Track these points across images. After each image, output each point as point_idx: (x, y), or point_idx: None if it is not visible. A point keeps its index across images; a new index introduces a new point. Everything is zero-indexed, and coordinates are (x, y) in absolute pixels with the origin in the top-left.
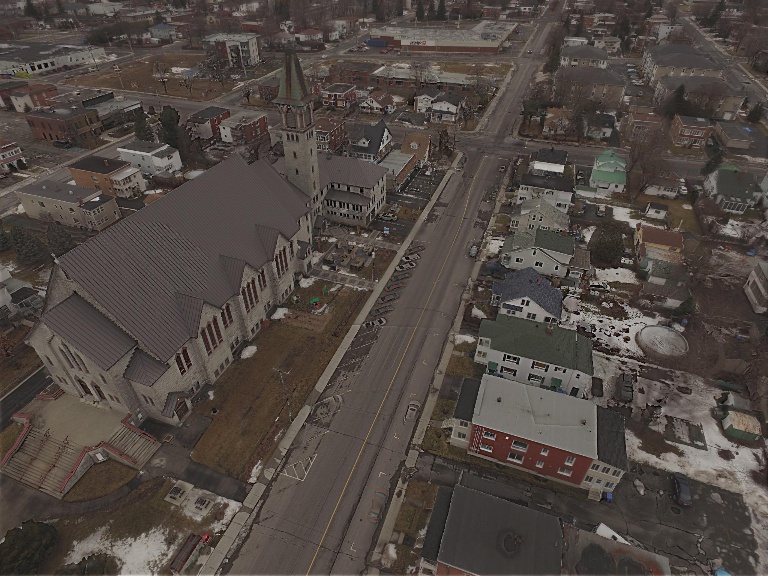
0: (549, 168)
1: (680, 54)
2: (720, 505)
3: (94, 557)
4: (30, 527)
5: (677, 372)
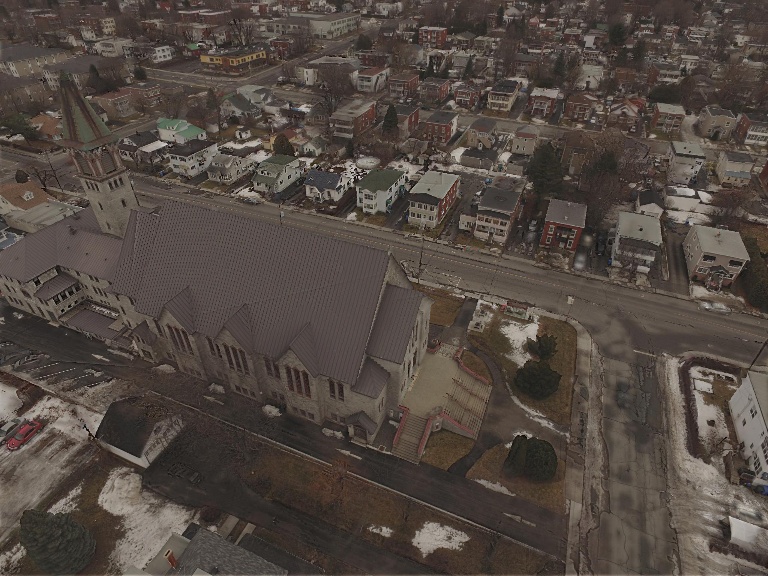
0: (156, 147)
1: (14, 48)
2: None
3: (529, 345)
4: (528, 365)
5: (389, 165)
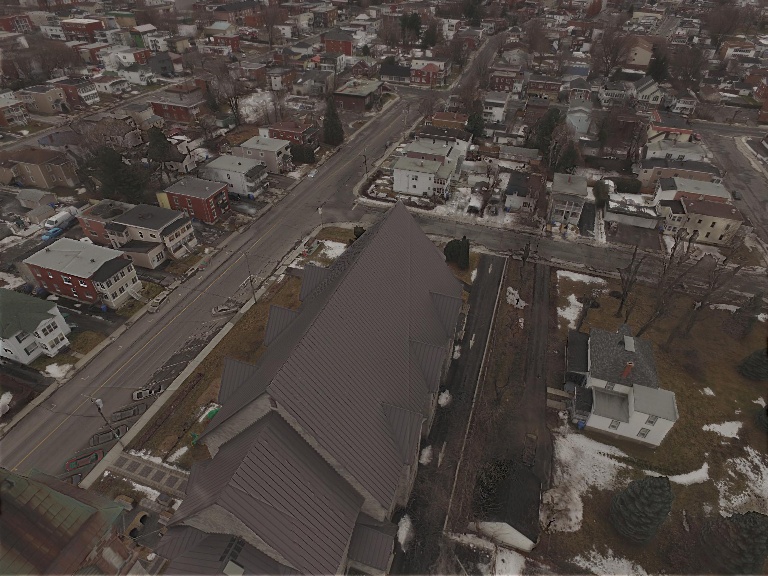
0: None
1: None
2: (2, 260)
3: None
4: None
5: None
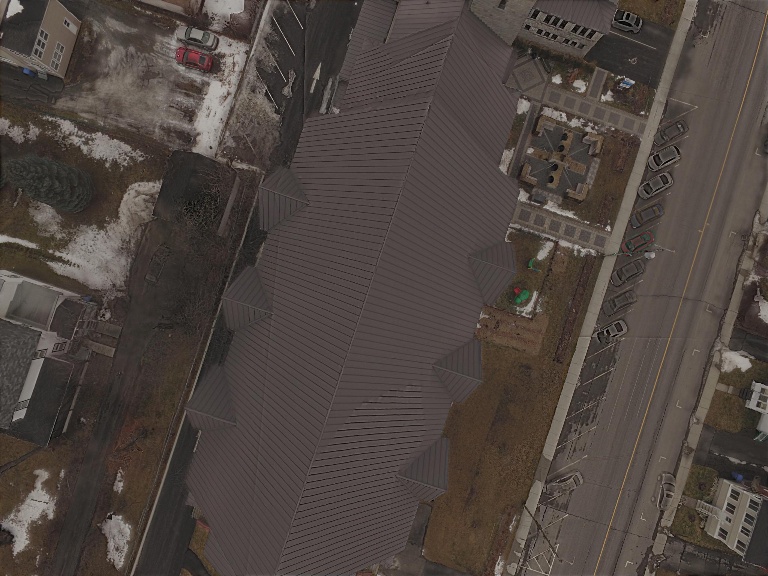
0: None
1: None
2: None
3: None
4: None
5: None
